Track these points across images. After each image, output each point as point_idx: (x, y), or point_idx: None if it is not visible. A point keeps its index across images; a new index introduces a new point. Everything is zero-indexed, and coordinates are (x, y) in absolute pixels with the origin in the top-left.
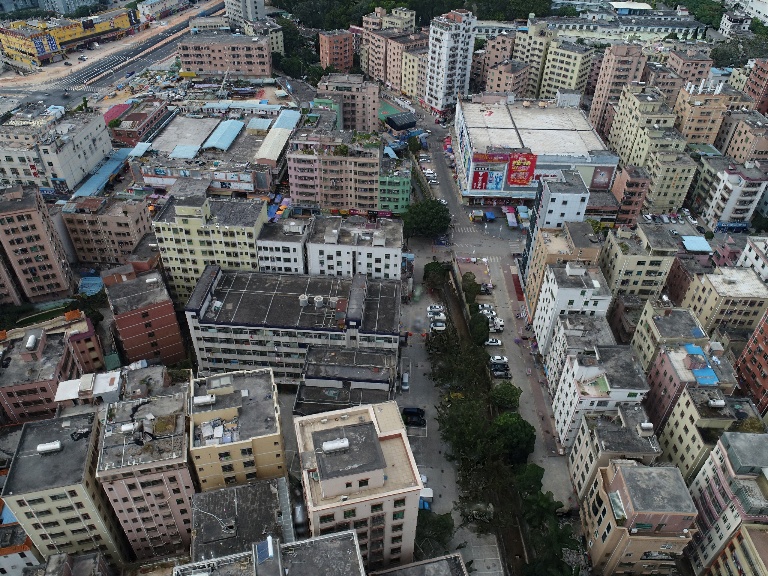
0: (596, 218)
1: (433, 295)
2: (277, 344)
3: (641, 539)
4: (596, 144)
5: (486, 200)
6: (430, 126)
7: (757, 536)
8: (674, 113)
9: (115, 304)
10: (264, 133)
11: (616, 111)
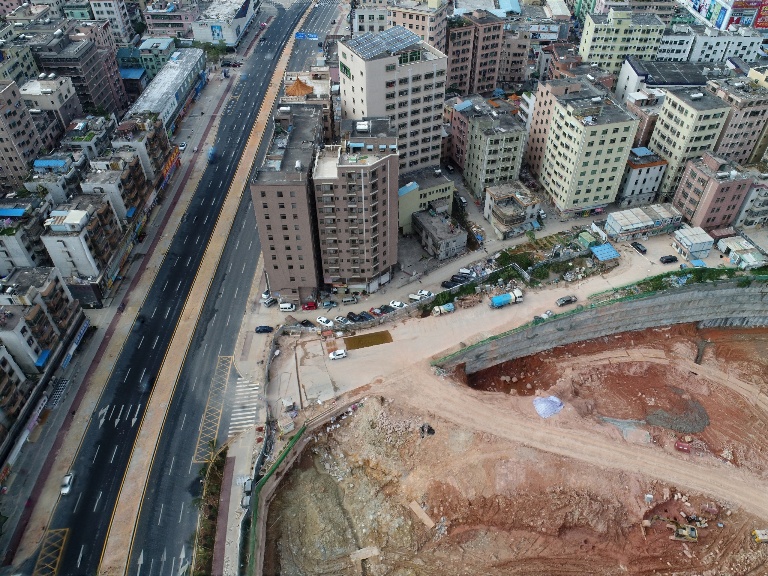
0: None
1: None
2: None
3: None
4: None
5: None
6: None
7: None
8: None
9: None
10: (538, 2)
11: None
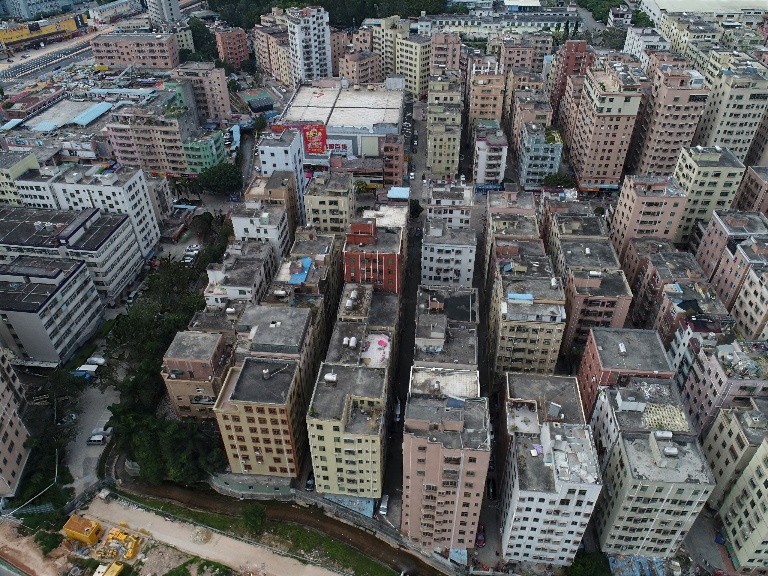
0: (365, 180)
1: (200, 238)
2: None
3: (176, 382)
4: (394, 119)
5: None
6: None
7: None
8: (459, 91)
9: None
10: None
11: None
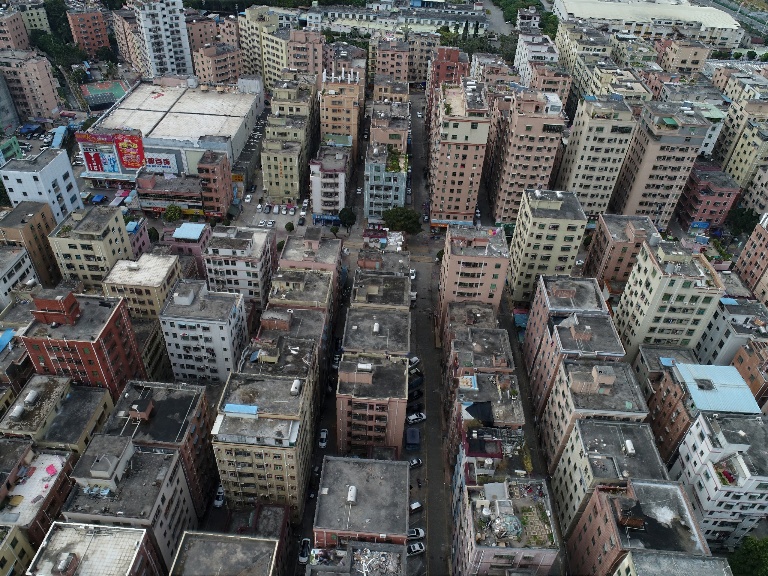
0: (181, 204)
1: None
2: None
3: None
4: (232, 130)
5: (113, 183)
6: None
7: None
8: (307, 101)
9: None
10: None
11: None
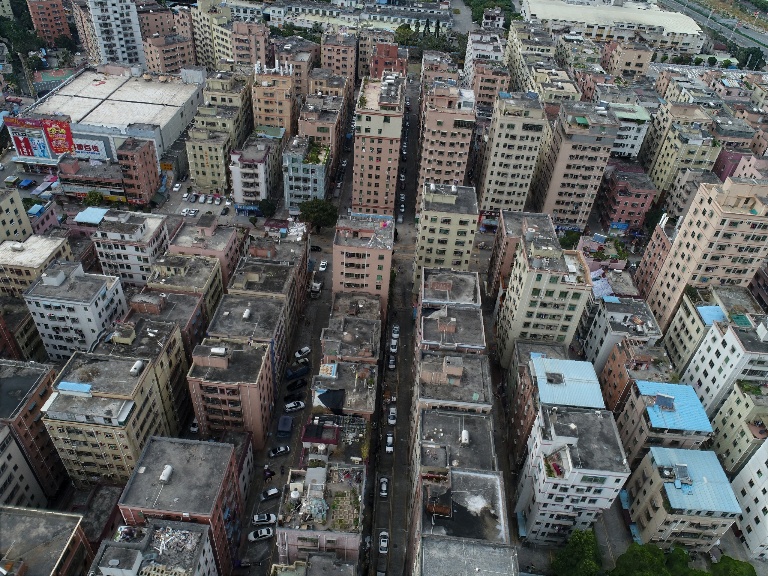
0: (103, 190)
1: None
2: None
3: None
4: (166, 119)
5: (45, 168)
6: None
7: None
8: (239, 92)
9: None
10: None
11: None
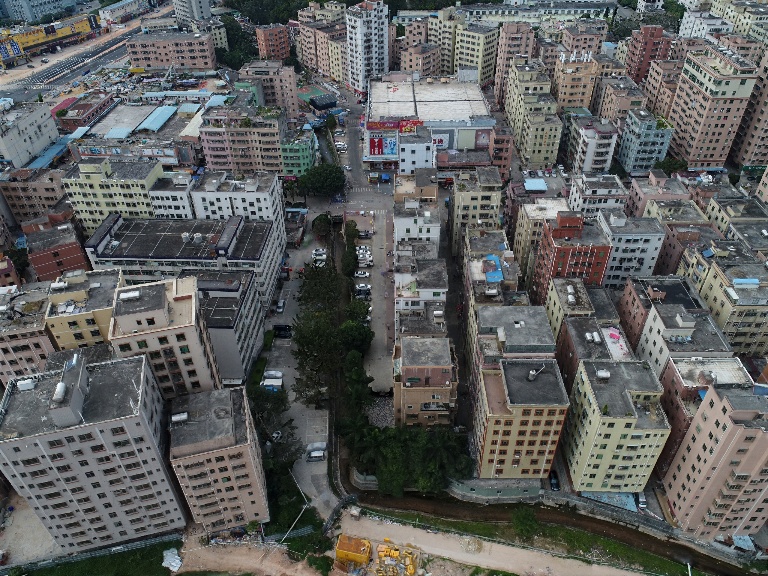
0: None
1: (321, 241)
2: (163, 273)
3: (413, 390)
4: (482, 111)
5: (386, 165)
6: (352, 106)
7: (491, 378)
8: (549, 80)
9: (31, 247)
10: (193, 116)
11: (508, 83)
